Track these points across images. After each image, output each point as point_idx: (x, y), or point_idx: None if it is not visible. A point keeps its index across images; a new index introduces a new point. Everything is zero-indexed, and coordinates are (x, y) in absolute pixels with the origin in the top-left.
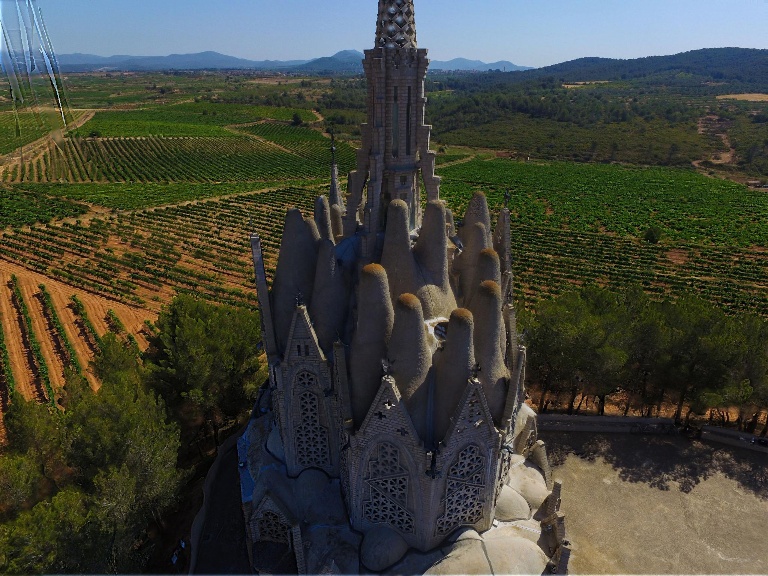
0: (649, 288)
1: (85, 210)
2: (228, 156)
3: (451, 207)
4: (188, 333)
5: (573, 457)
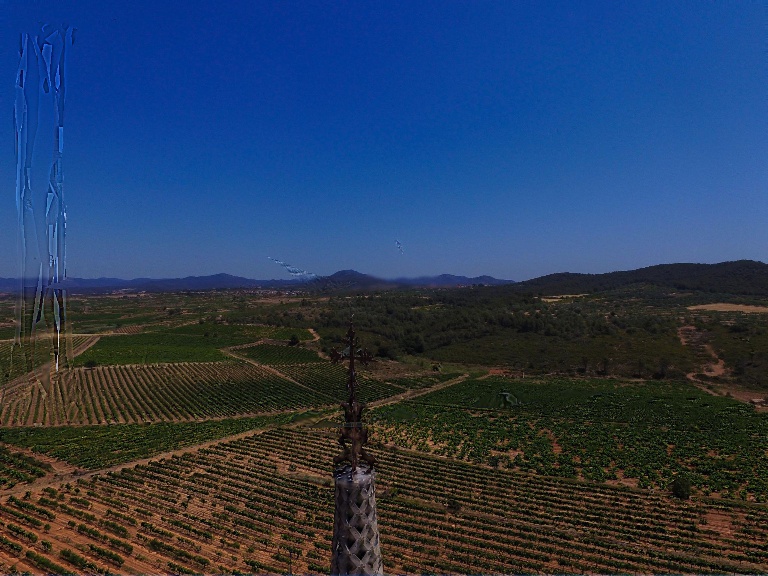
0: None
1: (44, 472)
2: (220, 385)
3: (450, 447)
4: None
5: None
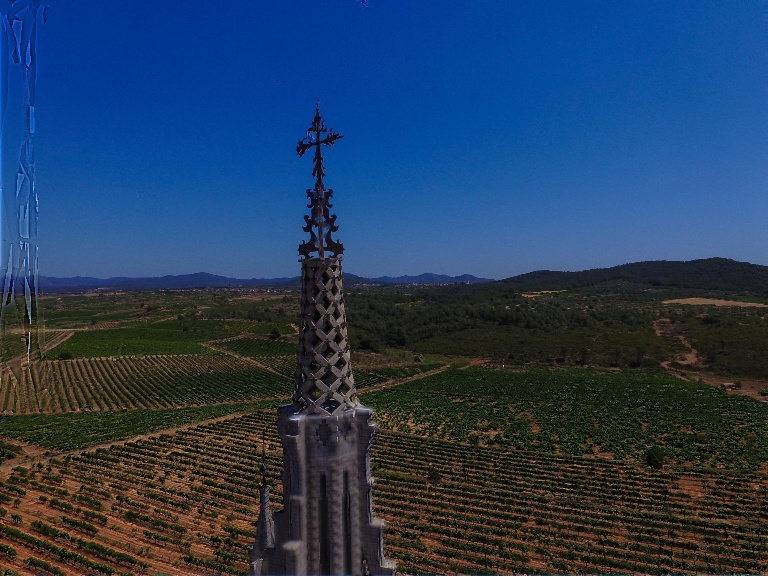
0: (679, 543)
1: (14, 454)
2: (199, 375)
3: (431, 428)
4: None
5: None
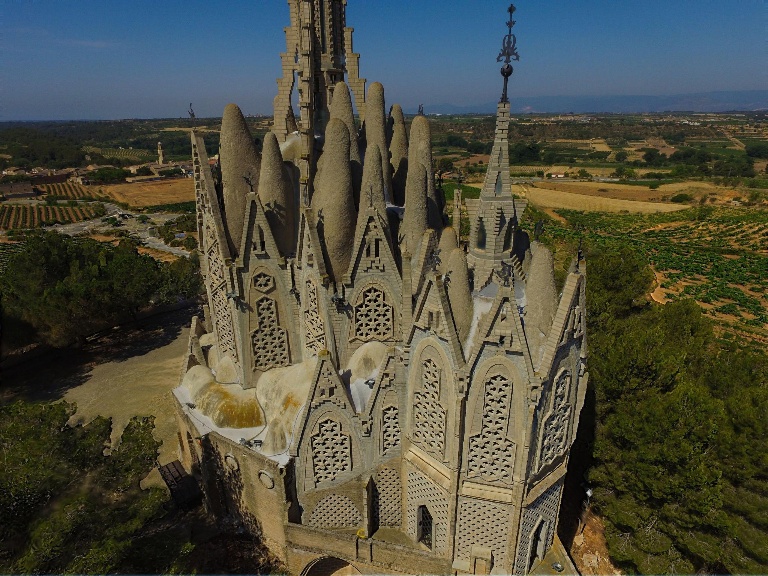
0: None
1: None
2: None
3: None
4: (636, 338)
5: None
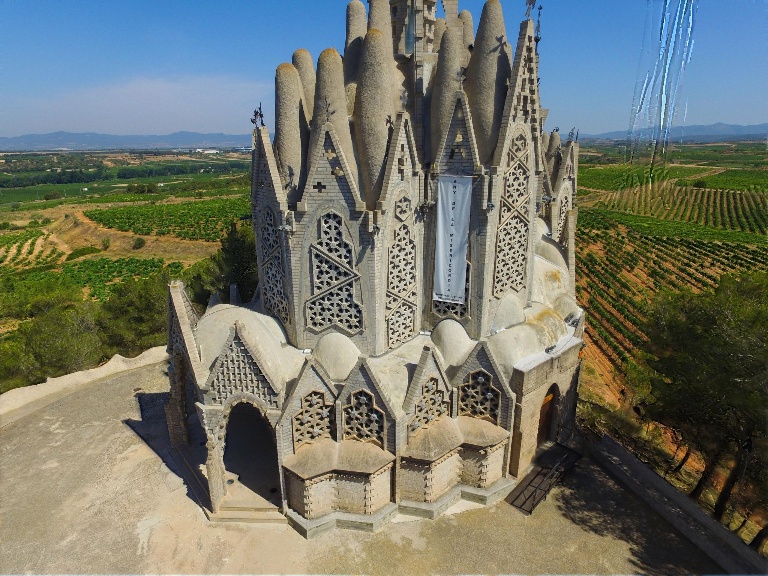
0: None
1: (610, 227)
2: None
3: None
4: None
5: (619, 546)
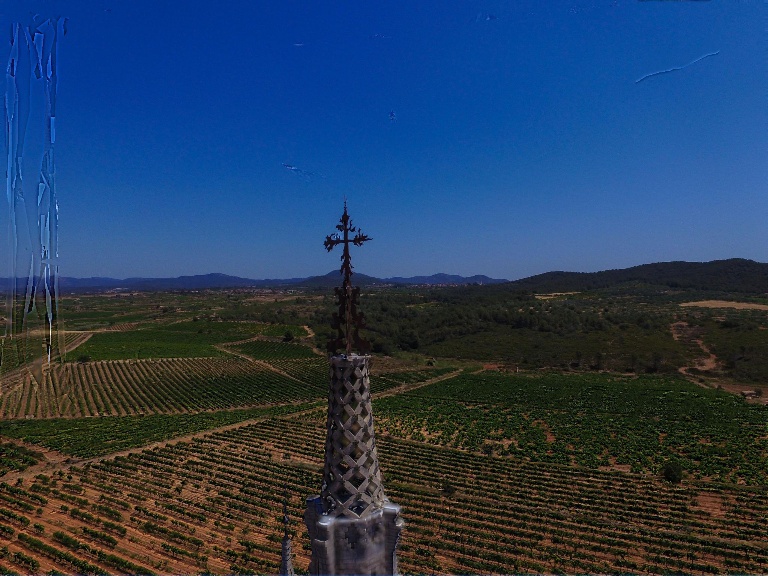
0: (698, 566)
1: (36, 461)
2: (214, 379)
3: (445, 436)
4: None
5: None
